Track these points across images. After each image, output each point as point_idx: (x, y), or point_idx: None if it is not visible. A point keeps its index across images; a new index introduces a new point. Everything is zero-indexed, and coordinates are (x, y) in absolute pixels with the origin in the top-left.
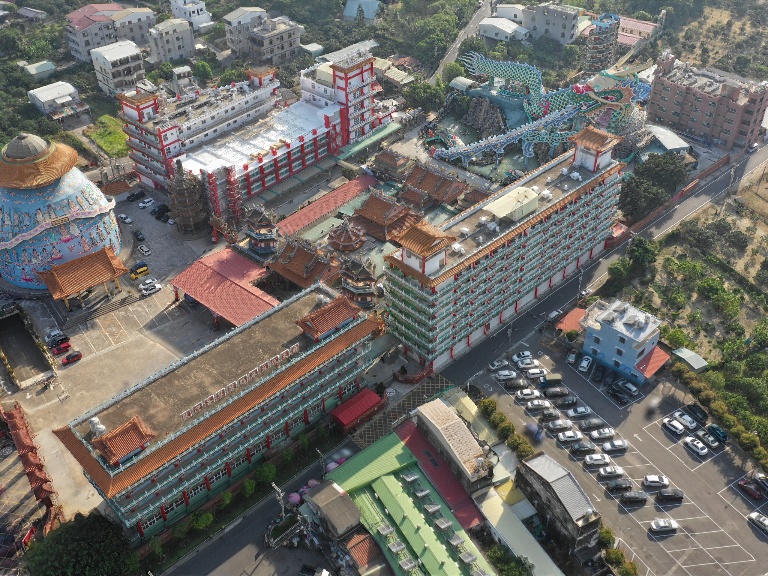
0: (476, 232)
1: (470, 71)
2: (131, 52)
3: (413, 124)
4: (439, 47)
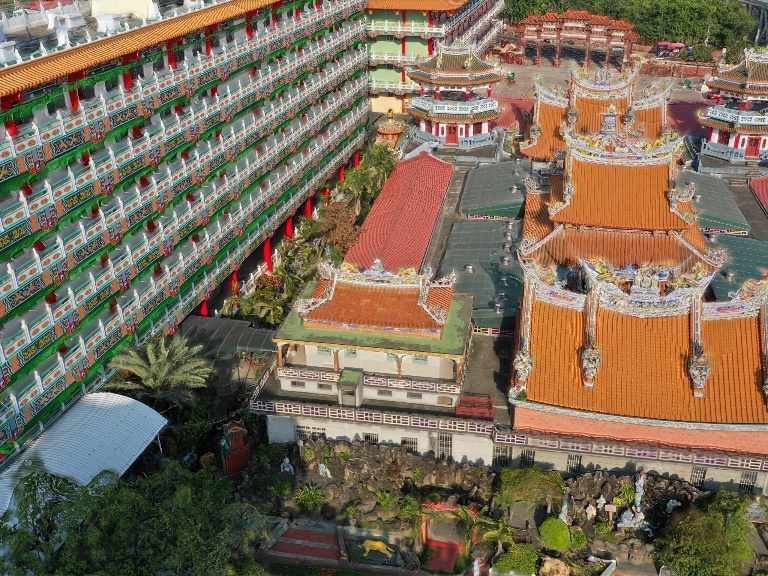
0: None
1: None
2: None
3: None
4: None
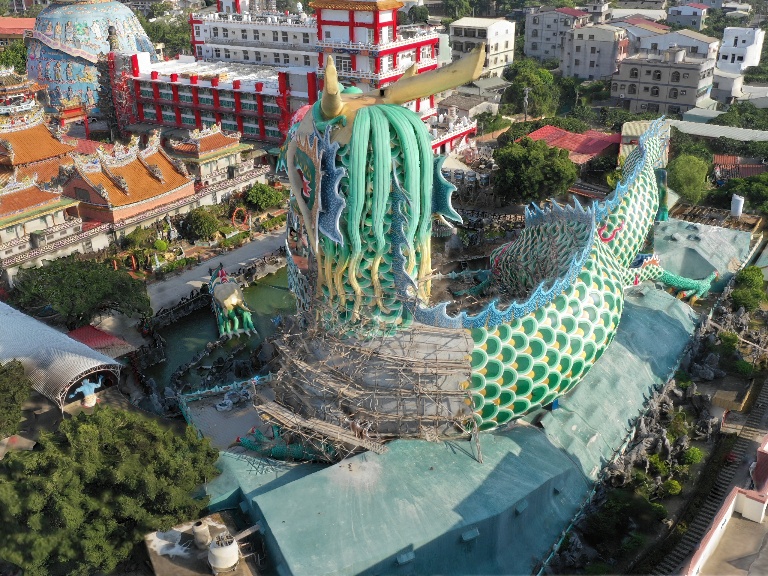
0: None
1: None
2: (481, 24)
3: (458, 198)
4: None
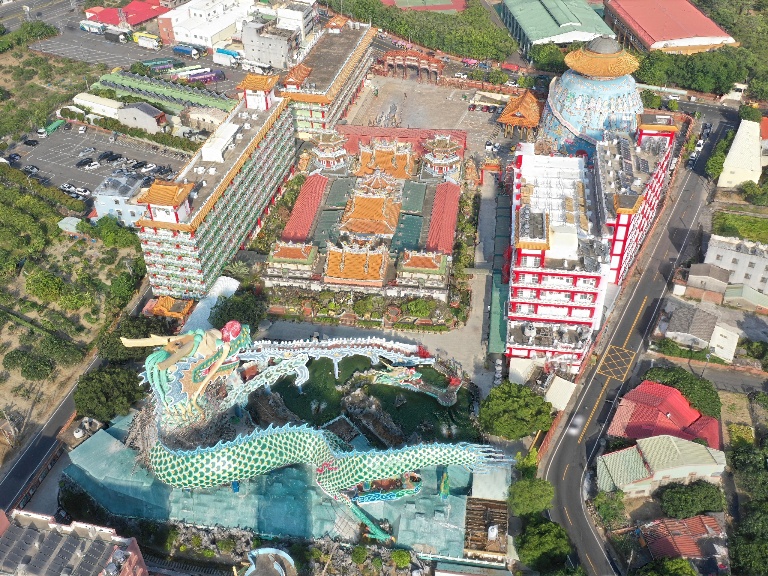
0: (240, 130)
1: (521, 535)
2: None
3: None
4: (642, 575)
